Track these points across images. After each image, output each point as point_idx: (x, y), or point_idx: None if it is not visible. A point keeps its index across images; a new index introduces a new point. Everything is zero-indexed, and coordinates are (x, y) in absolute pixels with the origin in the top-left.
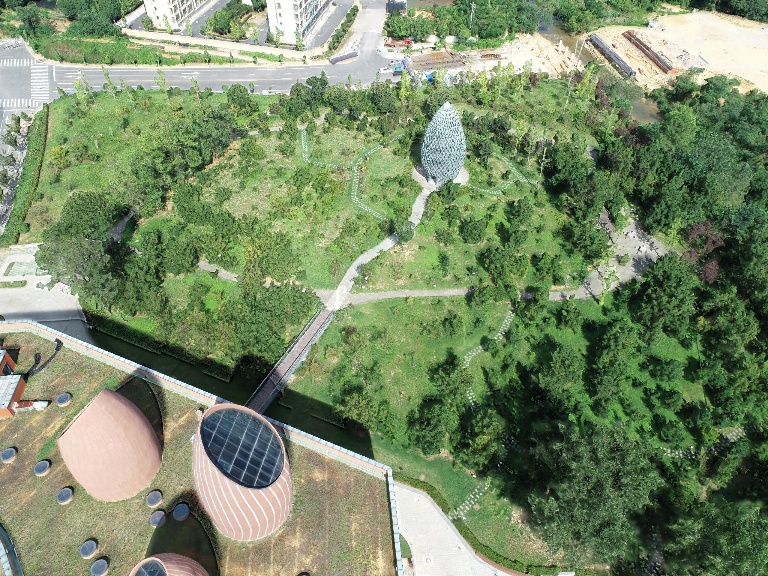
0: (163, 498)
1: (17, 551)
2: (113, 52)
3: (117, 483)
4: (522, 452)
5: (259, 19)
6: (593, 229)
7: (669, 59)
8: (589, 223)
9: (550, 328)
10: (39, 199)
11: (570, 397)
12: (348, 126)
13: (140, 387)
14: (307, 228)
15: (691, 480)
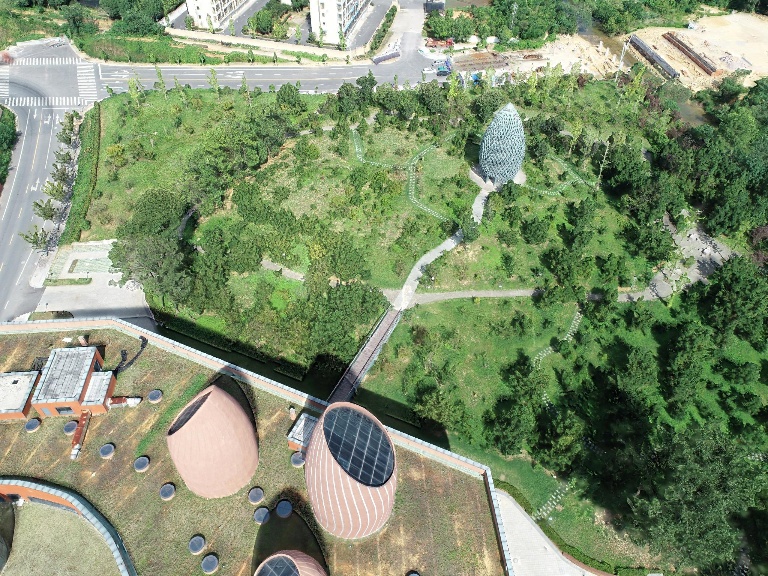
0: (264, 495)
1: (126, 546)
2: (158, 51)
3: (223, 480)
4: (600, 453)
5: (298, 19)
6: (659, 231)
7: (712, 61)
8: (655, 225)
9: (619, 330)
10: (98, 197)
11: (646, 399)
12: (400, 126)
13: (229, 385)
14: (368, 228)
15: None
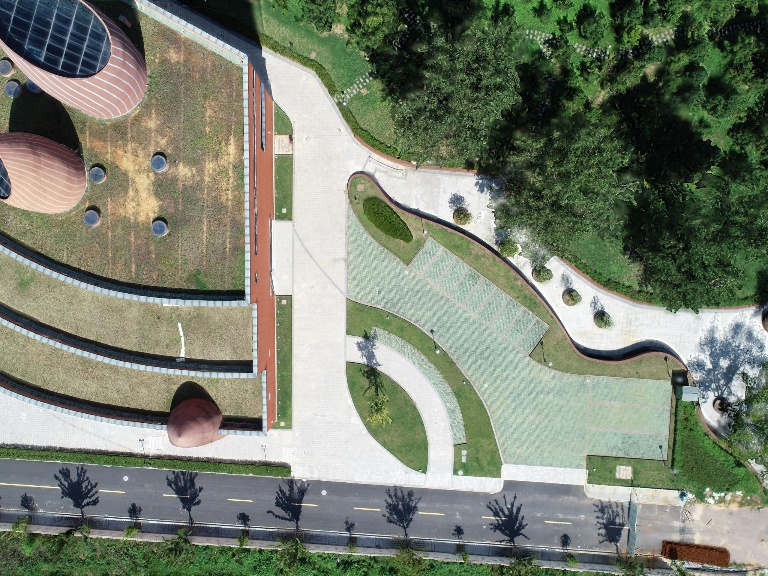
0: (15, 68)
1: None
2: None
3: None
4: None
5: None
6: None
7: None
8: None
9: None
10: None
11: None
12: None
13: None
14: None
15: (590, 84)
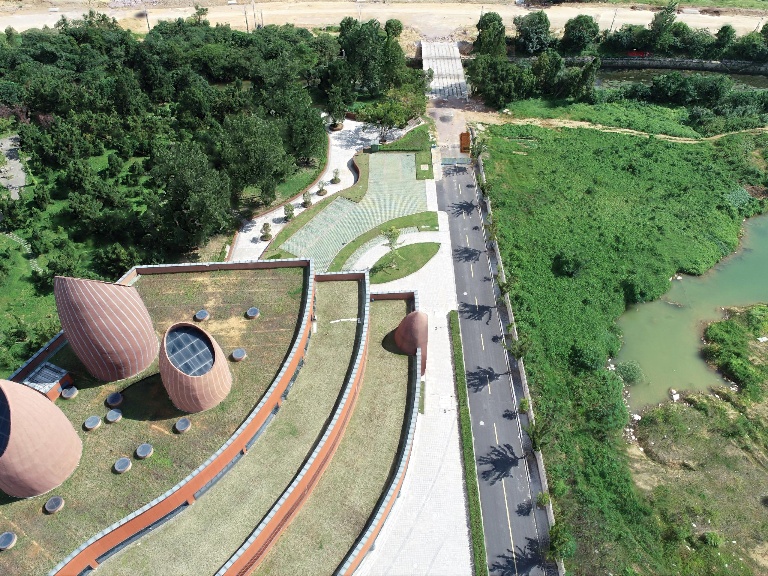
0: None
1: None
2: None
3: (70, 429)
4: None
5: None
6: None
7: None
8: None
9: None
10: None
11: None
12: None
13: None
14: None
15: None
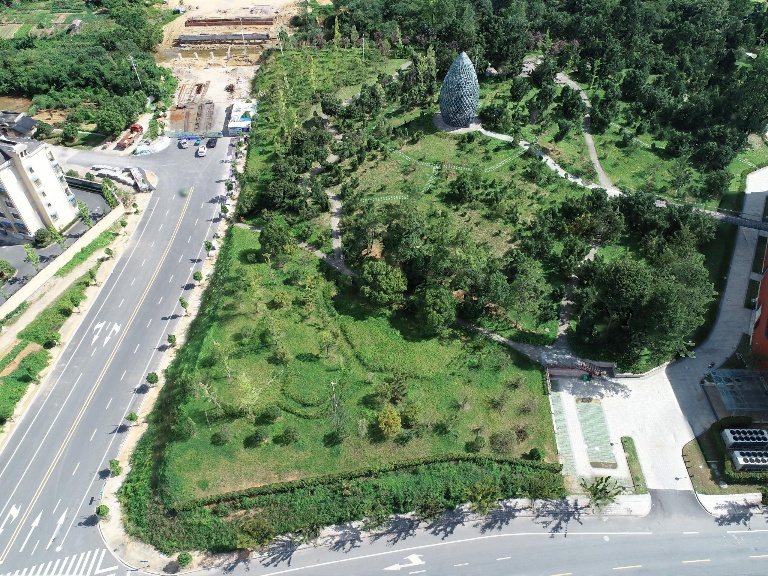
0: None
1: None
2: None
3: None
4: None
5: None
6: None
7: (253, 17)
8: None
9: None
10: None
11: None
12: (357, 166)
13: None
14: (526, 201)
15: None
